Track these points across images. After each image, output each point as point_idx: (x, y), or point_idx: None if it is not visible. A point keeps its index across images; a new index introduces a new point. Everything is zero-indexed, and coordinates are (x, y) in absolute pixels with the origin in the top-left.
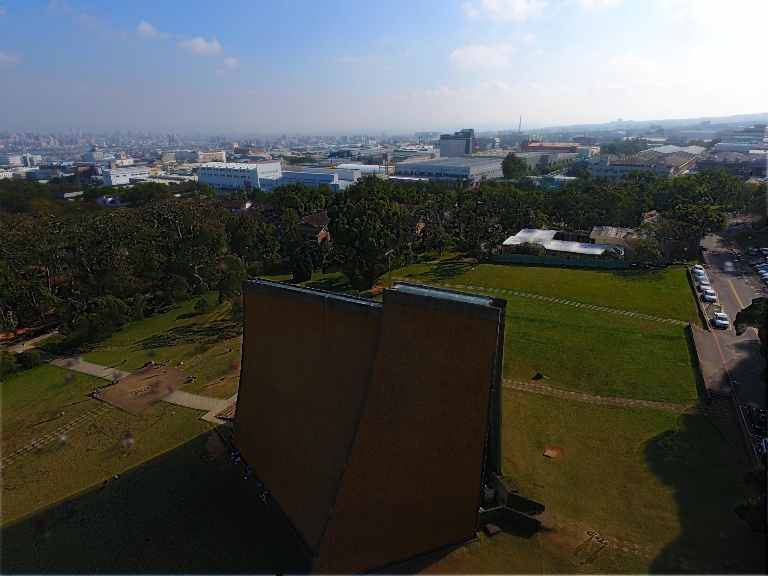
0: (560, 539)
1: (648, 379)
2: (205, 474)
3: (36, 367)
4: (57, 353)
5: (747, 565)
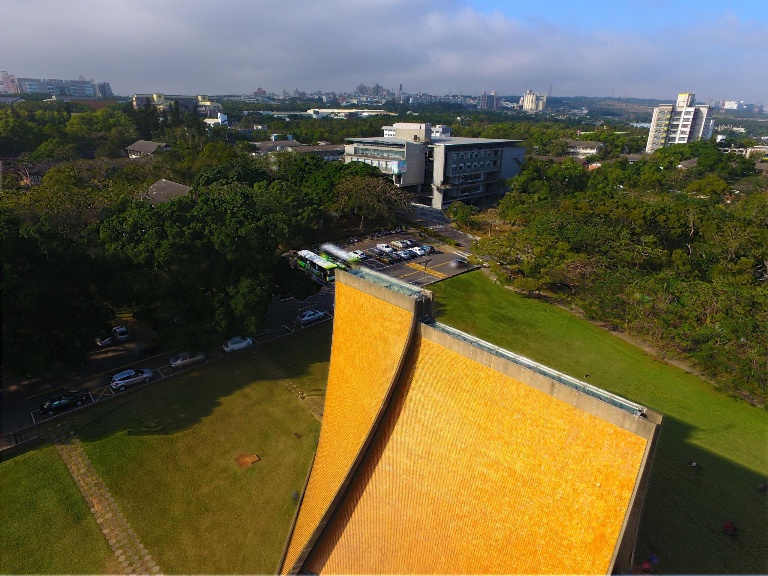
0: None
1: (0, 502)
2: (636, 543)
3: None
4: None
5: (251, 360)
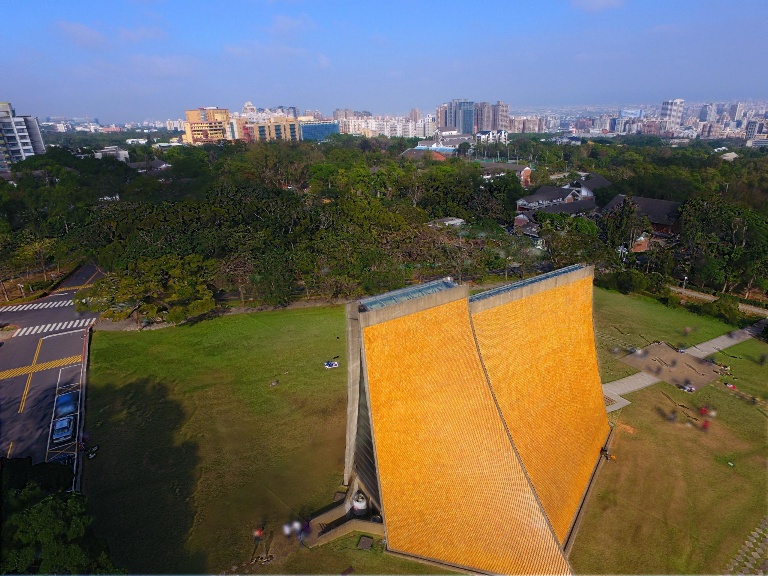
0: (289, 532)
1: None
2: None
3: (729, 325)
4: (764, 331)
5: None
